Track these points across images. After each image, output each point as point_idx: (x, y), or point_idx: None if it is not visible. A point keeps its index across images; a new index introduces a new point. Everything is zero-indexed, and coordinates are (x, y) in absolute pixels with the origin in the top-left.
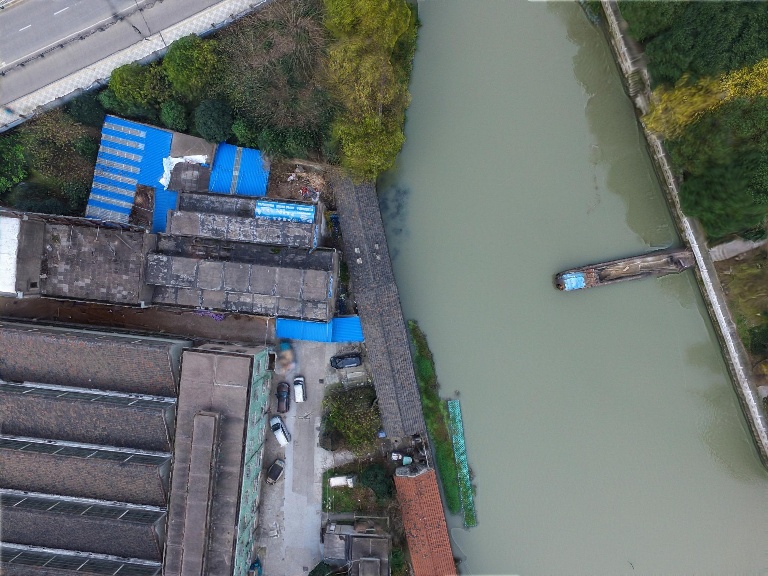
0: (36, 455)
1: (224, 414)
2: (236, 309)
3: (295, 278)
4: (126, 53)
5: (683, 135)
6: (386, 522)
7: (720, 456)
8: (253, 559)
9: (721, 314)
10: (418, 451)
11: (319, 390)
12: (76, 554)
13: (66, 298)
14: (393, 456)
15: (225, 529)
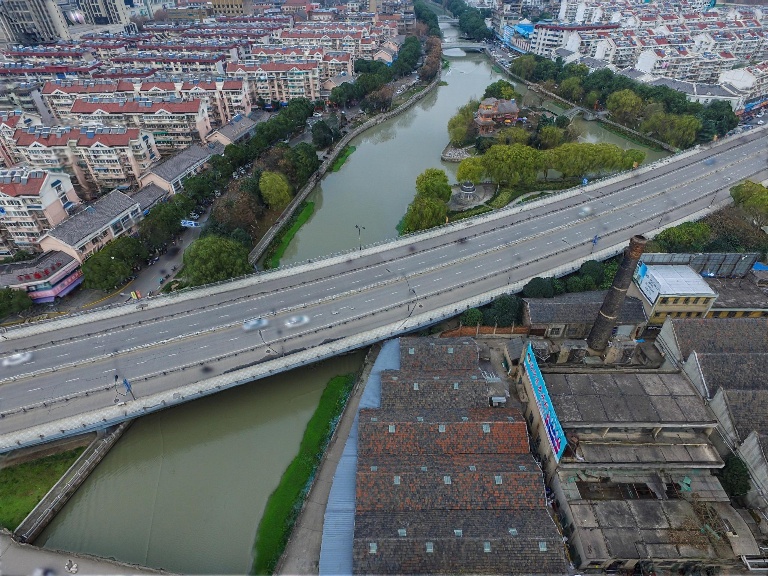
0: None
1: None
2: None
3: None
4: (651, 232)
5: None
6: None
7: None
8: None
9: None
10: None
11: None
12: None
13: (728, 308)
14: None
15: None
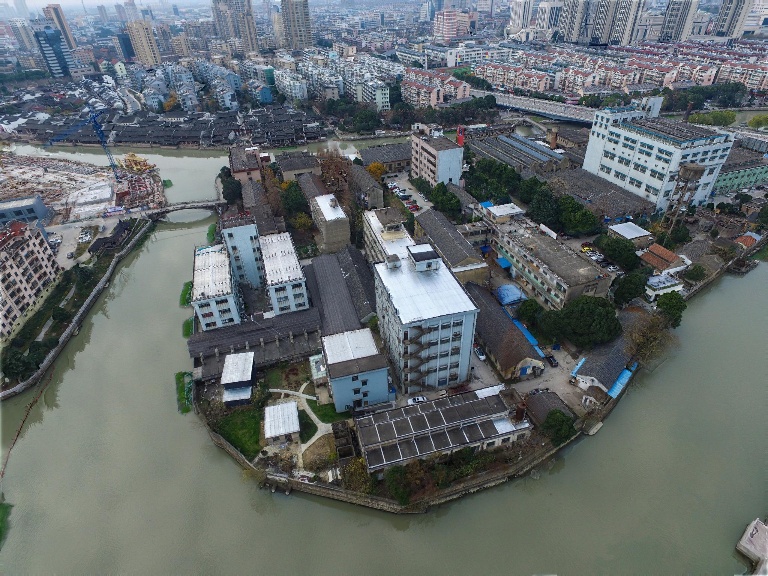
0: None
1: (762, 162)
2: None
3: None
4: None
5: None
6: None
7: None
8: None
9: None
10: None
11: None
12: None
13: None
14: None
15: None
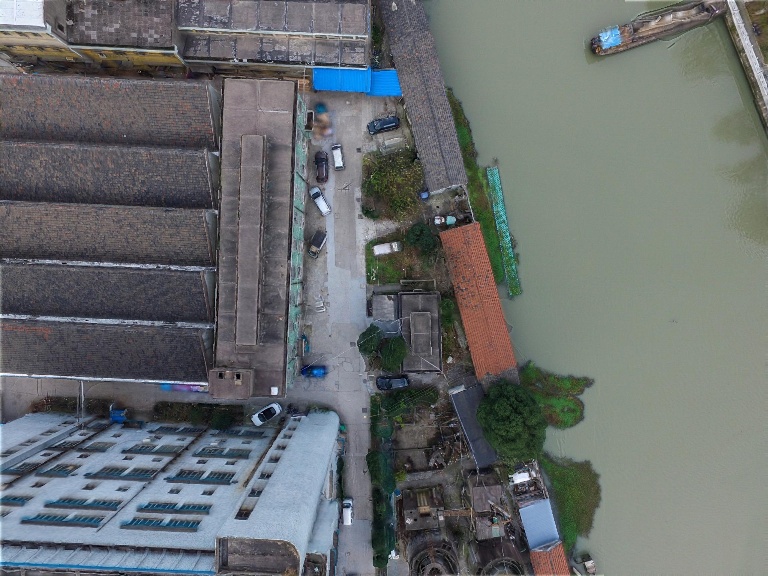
0: (75, 207)
1: (270, 142)
2: (271, 59)
3: (332, 13)
4: None
5: None
6: (433, 284)
7: (750, 235)
8: (300, 334)
9: (754, 55)
10: (461, 211)
11: (357, 159)
12: (121, 323)
13: (95, 45)
14: (436, 220)
15: (278, 262)
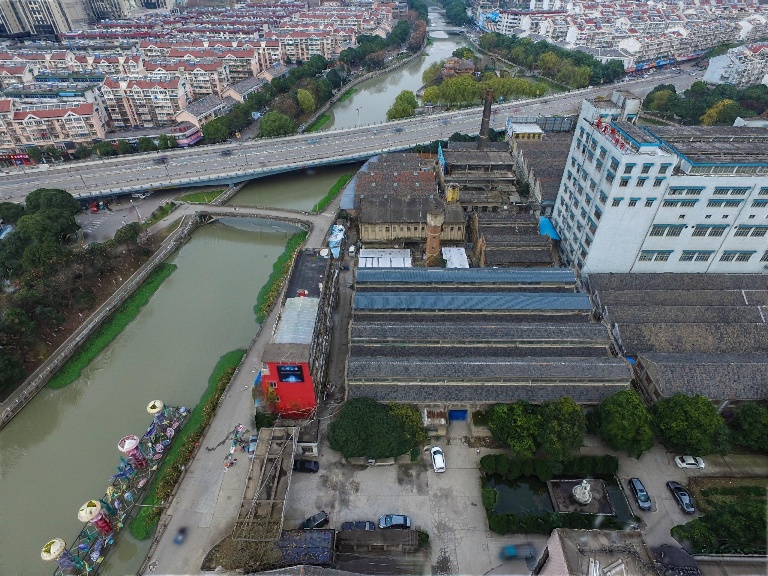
0: None
1: None
2: None
3: None
4: None
5: (718, 118)
6: None
7: None
8: None
9: None
10: None
11: None
12: None
13: None
14: None
15: None
